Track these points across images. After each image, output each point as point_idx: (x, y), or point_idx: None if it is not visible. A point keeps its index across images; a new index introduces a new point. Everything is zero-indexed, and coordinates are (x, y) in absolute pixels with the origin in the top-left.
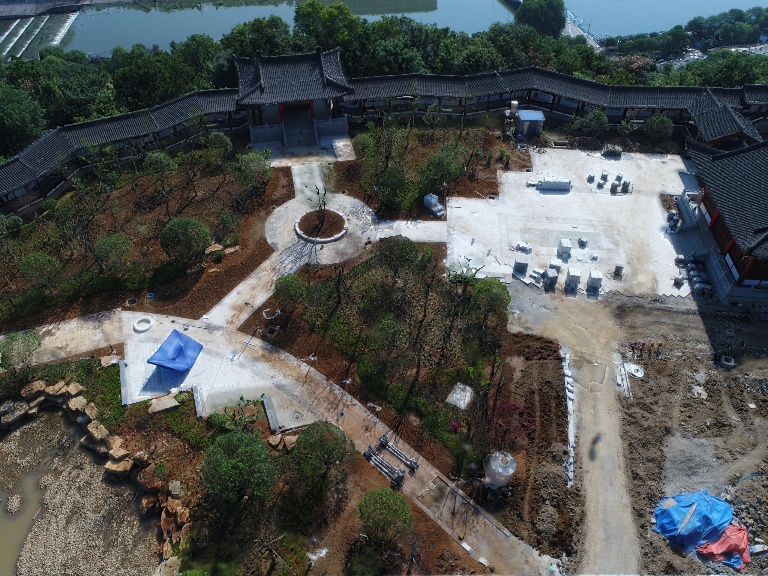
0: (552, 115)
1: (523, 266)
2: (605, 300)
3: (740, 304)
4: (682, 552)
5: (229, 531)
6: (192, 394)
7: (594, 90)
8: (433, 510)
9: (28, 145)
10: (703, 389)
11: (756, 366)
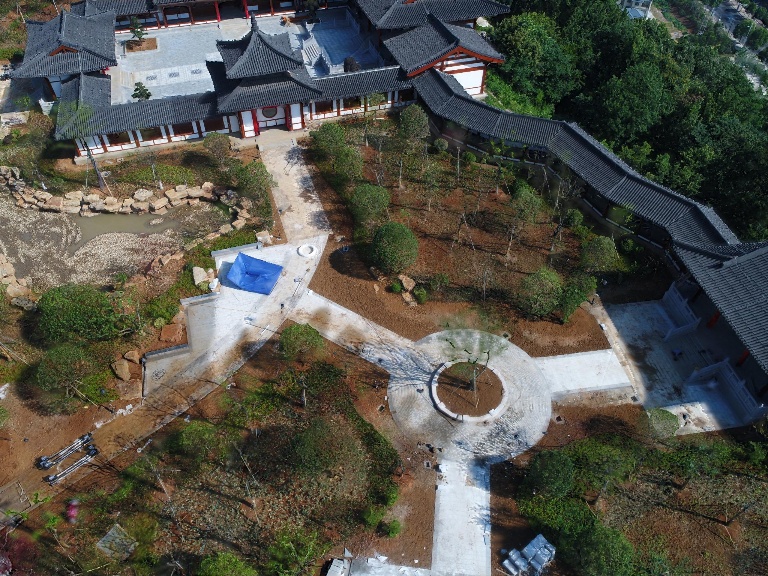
0: None
1: None
2: None
3: None
4: None
5: None
6: (207, 293)
7: None
8: None
9: (601, 132)
10: None
11: None
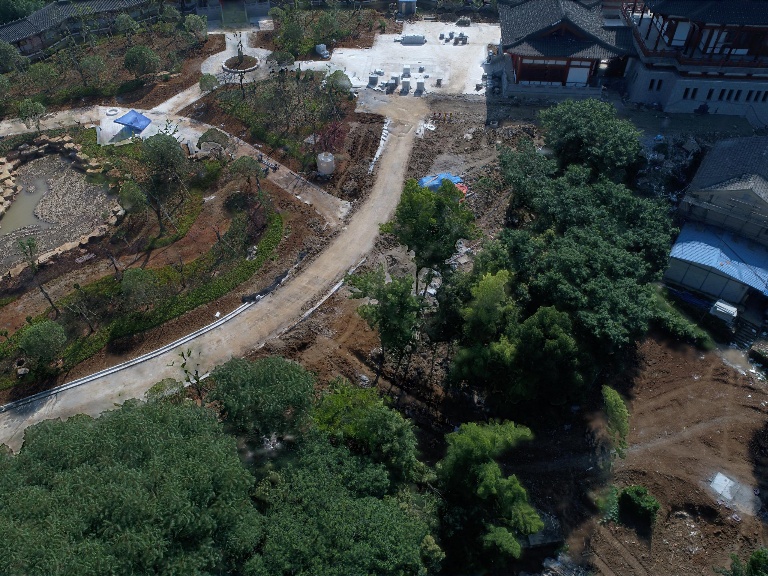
0: (429, 2)
1: (374, 80)
2: (425, 97)
3: (515, 97)
4: None
5: (159, 191)
6: (142, 140)
7: None
8: (283, 185)
9: None
10: (471, 135)
11: (510, 125)
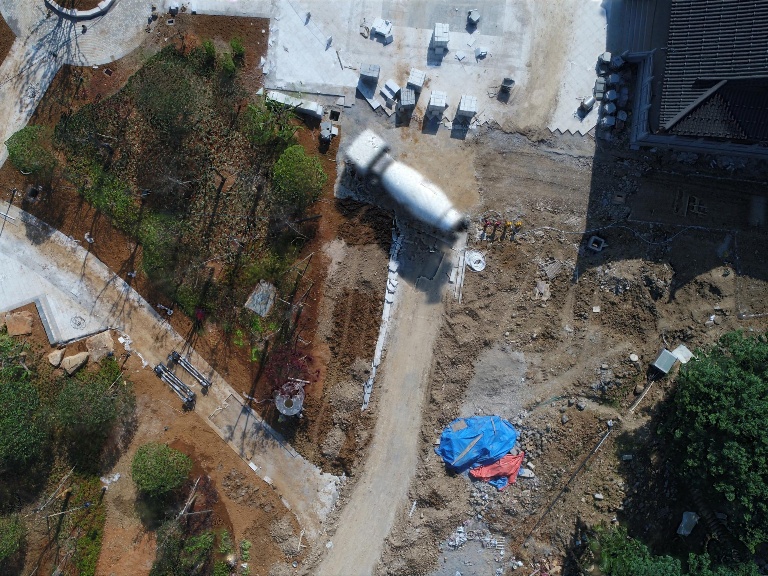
0: None
1: (371, 78)
2: (474, 140)
3: (653, 150)
4: (454, 474)
5: None
6: None
7: None
8: (224, 430)
9: None
10: (548, 287)
11: (626, 254)
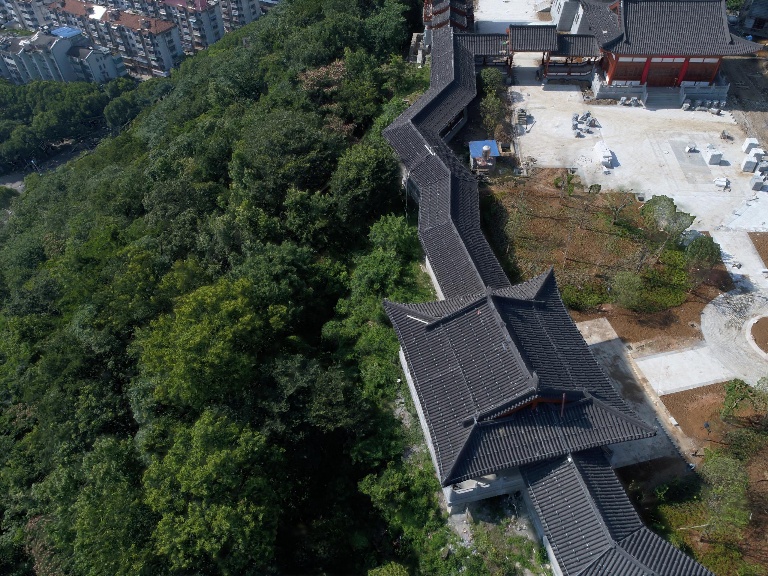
0: None
1: None
2: (764, 148)
3: None
4: None
5: None
6: None
7: (453, 93)
8: None
9: None
10: None
11: None
